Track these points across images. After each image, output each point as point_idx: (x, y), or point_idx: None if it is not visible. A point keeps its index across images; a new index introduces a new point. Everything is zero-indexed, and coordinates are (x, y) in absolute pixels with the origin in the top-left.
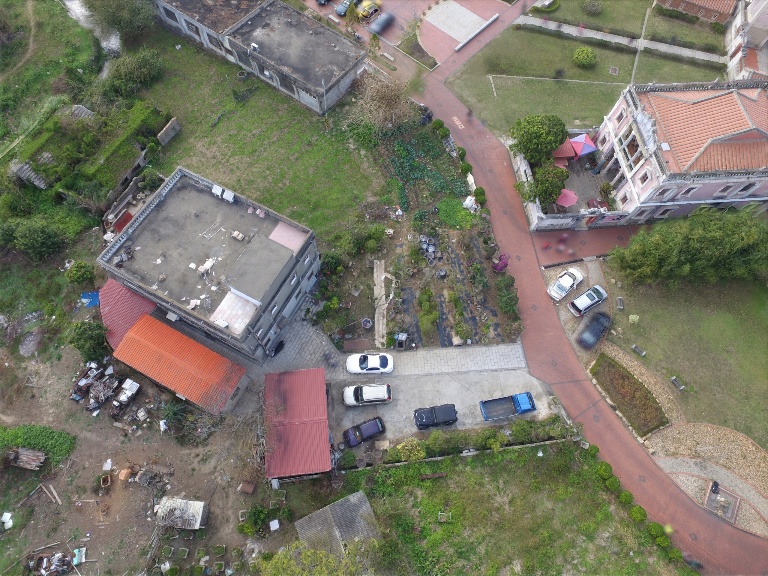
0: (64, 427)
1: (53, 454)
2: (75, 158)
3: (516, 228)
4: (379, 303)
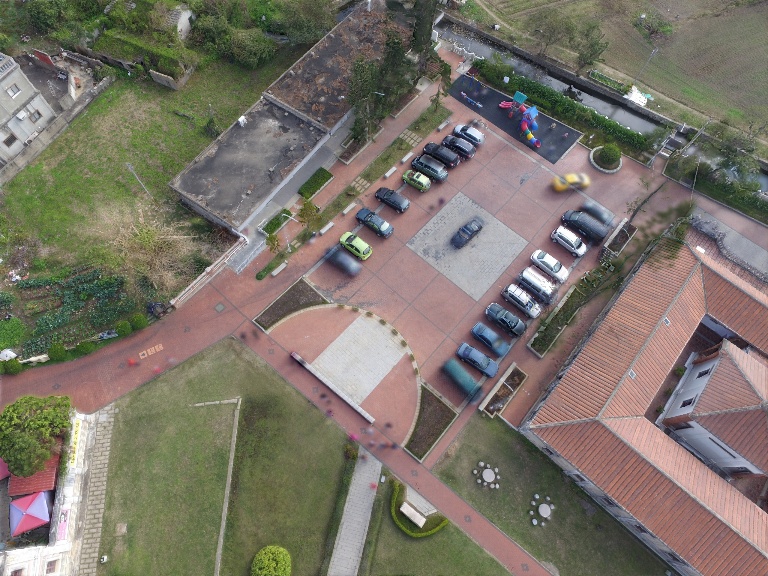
0: None
1: None
2: (124, 21)
3: None
4: None
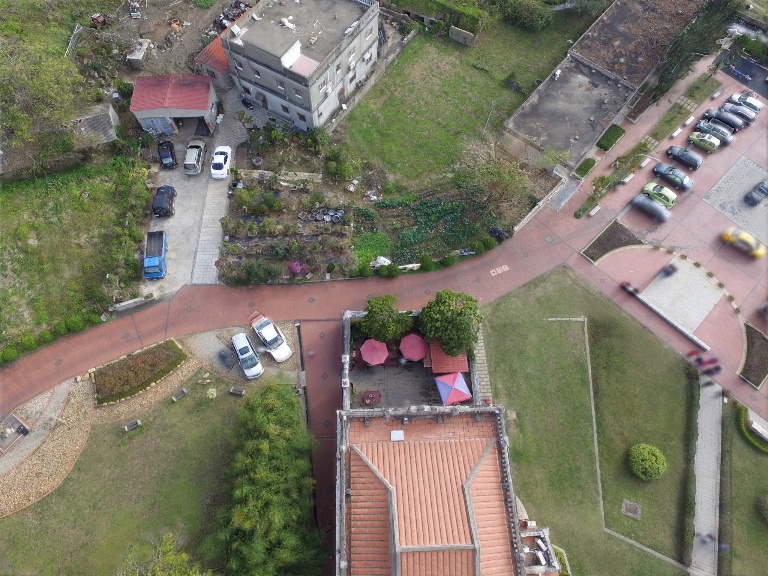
0: (217, 3)
1: (201, 0)
2: None
3: (349, 305)
4: None
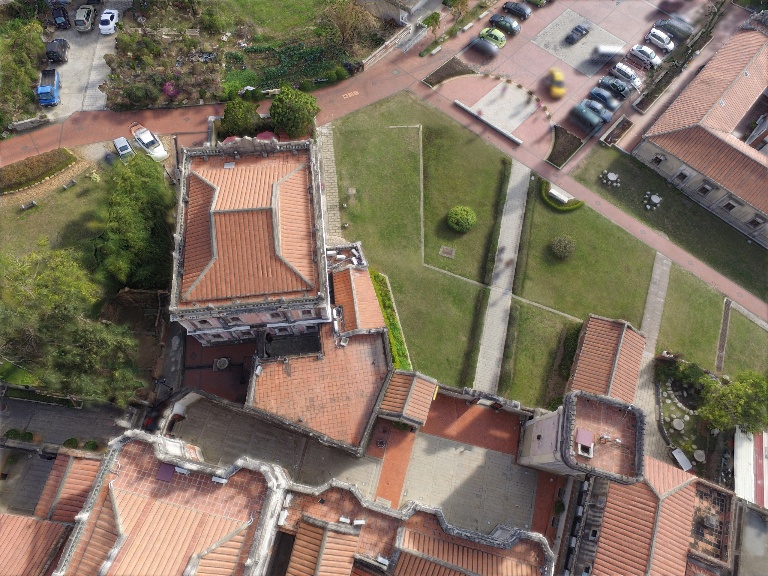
0: None
1: None
2: None
3: None
4: (160, 30)
